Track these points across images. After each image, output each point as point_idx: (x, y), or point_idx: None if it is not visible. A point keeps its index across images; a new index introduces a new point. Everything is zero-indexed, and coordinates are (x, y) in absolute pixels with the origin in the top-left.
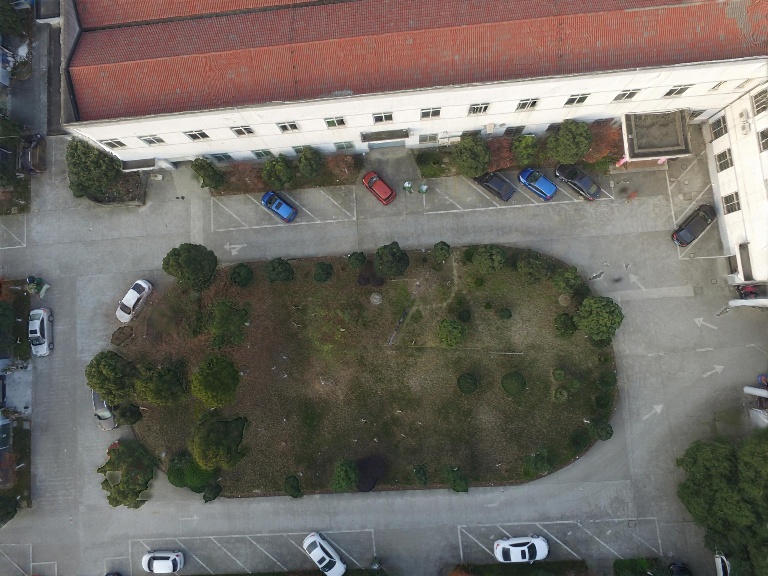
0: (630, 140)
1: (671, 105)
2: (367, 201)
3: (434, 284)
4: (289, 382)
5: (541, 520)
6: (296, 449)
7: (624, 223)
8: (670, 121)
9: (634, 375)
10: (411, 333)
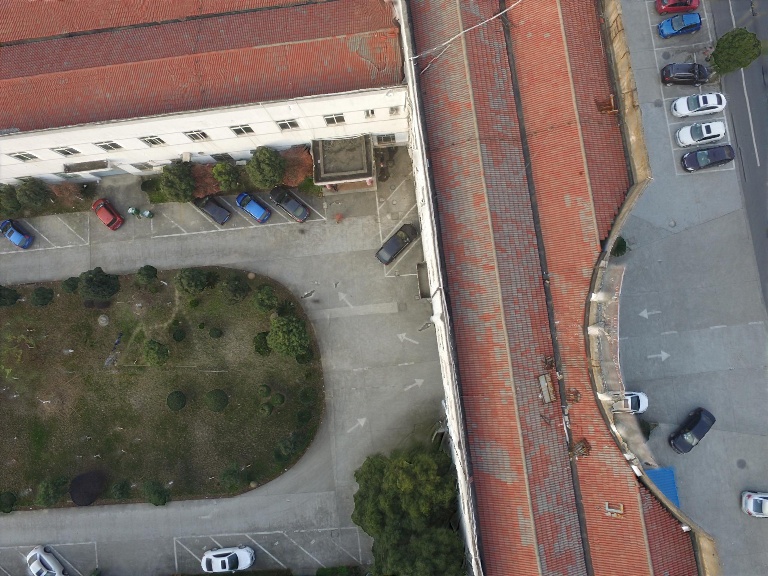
0: (318, 165)
1: (349, 131)
2: (100, 227)
3: (157, 305)
4: (21, 402)
5: (250, 531)
6: (26, 466)
7: (335, 243)
8: (357, 146)
9: (340, 390)
10: (134, 353)
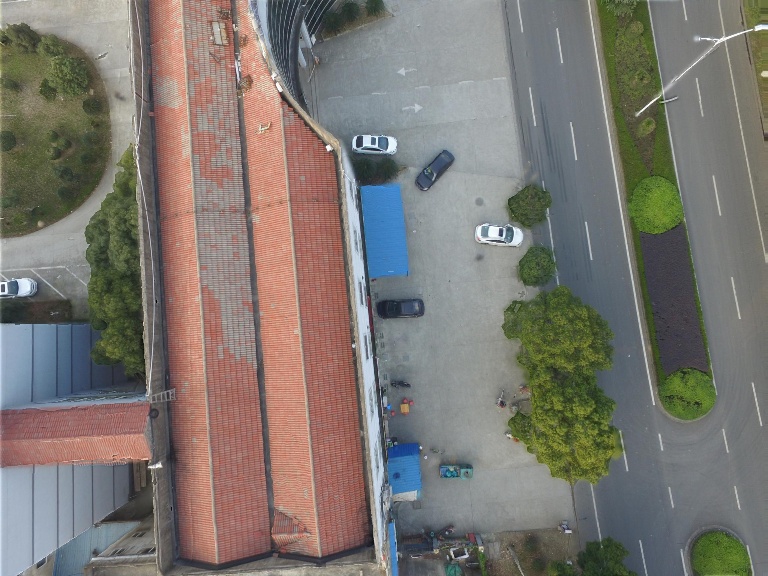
0: None
1: None
2: None
3: None
4: None
5: (35, 266)
6: None
7: None
8: None
9: (125, 140)
10: None
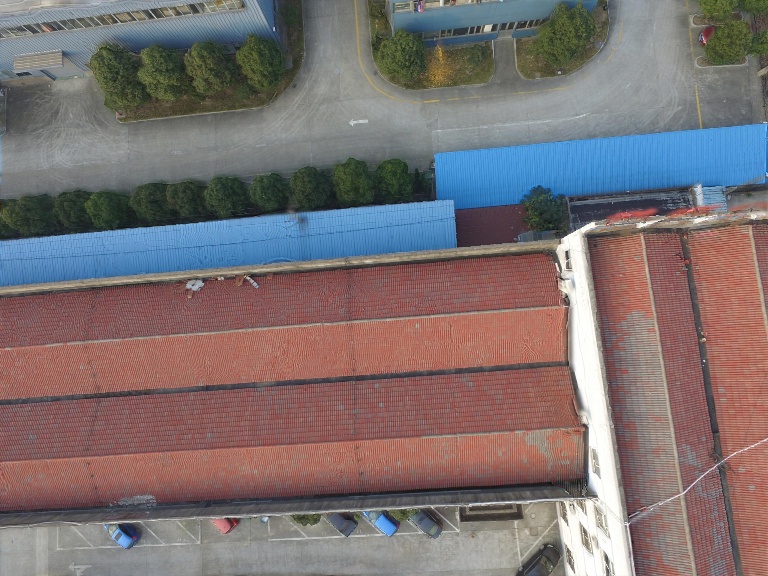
0: None
1: None
2: (212, 524)
3: None
4: None
5: None
6: None
7: (469, 558)
8: None
9: None
10: None
